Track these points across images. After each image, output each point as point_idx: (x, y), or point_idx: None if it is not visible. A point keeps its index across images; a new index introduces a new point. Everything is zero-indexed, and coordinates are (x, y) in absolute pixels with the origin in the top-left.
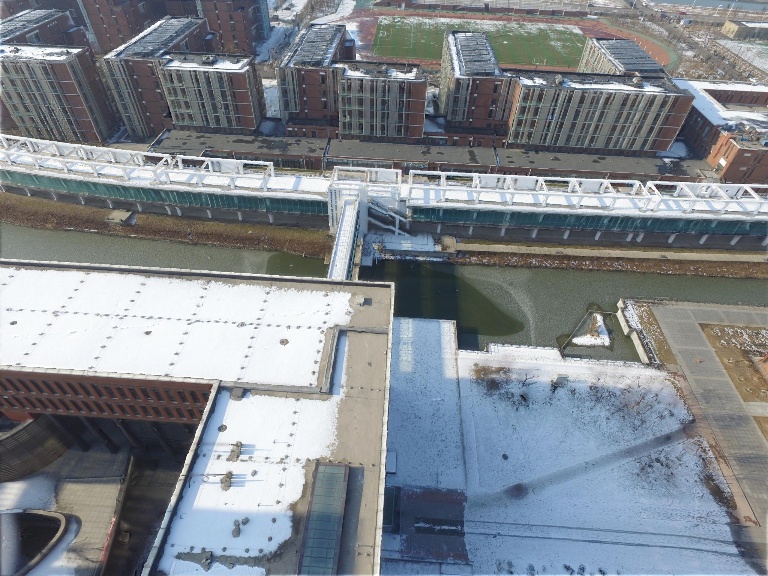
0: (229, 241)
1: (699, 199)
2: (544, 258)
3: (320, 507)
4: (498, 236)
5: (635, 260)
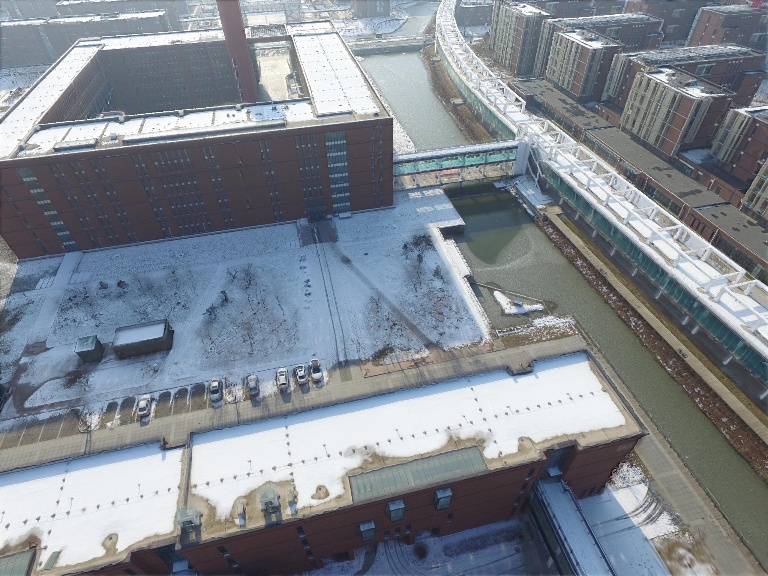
0: (471, 136)
1: (765, 319)
2: (590, 267)
3: (267, 121)
4: (589, 234)
5: (653, 331)
